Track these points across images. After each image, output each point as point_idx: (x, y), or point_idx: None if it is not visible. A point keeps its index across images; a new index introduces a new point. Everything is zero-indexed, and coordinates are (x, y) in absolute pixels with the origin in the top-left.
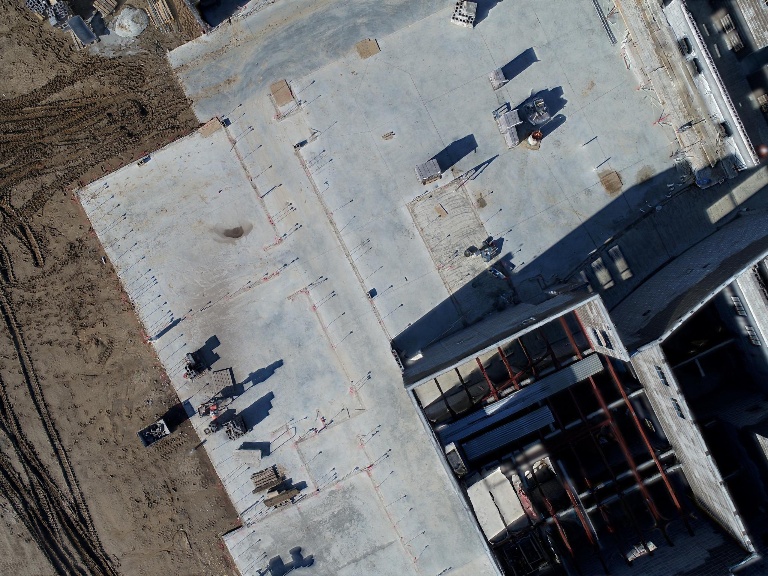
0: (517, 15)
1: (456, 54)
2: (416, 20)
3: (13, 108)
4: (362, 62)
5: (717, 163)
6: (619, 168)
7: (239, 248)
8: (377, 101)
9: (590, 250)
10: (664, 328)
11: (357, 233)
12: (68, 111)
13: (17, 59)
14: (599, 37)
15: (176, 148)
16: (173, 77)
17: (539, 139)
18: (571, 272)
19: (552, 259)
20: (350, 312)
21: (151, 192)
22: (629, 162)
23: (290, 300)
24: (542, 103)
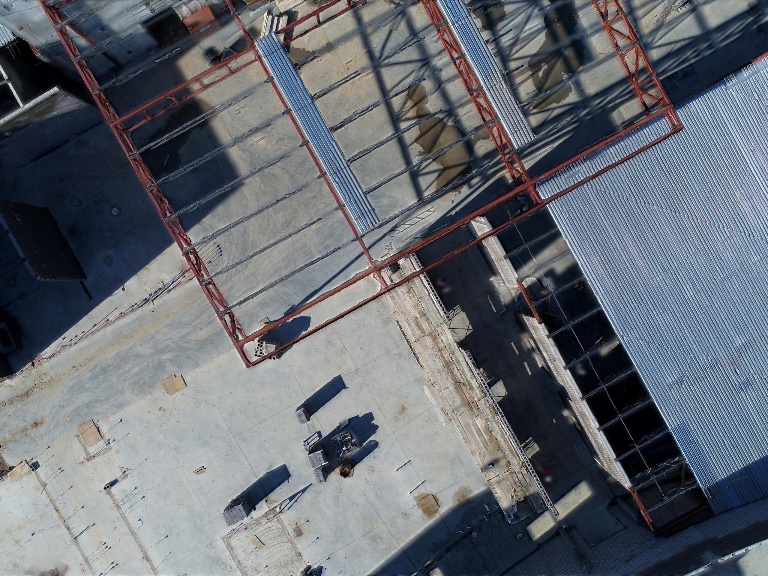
0: (323, 343)
1: (263, 385)
2: (221, 354)
3: None
4: (169, 398)
5: (524, 499)
6: (435, 490)
7: None
8: (186, 436)
9: (410, 573)
10: None
11: (174, 569)
12: None
13: None
14: (407, 361)
15: None
16: None
17: None
18: None
19: None
20: None
21: None
22: (445, 484)
23: None
24: (349, 438)
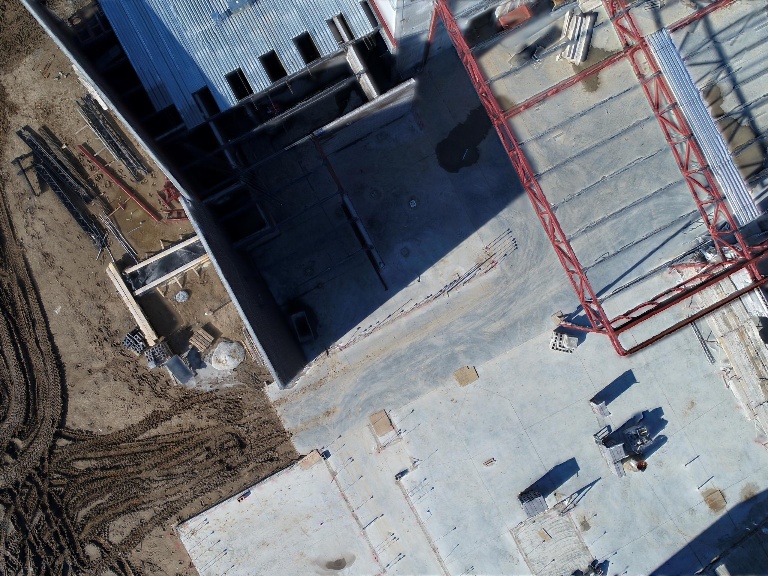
0: None
1: (555, 378)
2: (514, 346)
3: (110, 443)
4: (461, 390)
5: None
6: (722, 486)
7: None
8: (477, 428)
9: (696, 570)
10: None
11: (461, 561)
12: (166, 446)
13: (113, 394)
14: (697, 357)
15: (276, 481)
16: (271, 410)
17: (644, 470)
18: None
19: None
20: None
21: (252, 526)
22: (732, 480)
23: None
24: (645, 432)
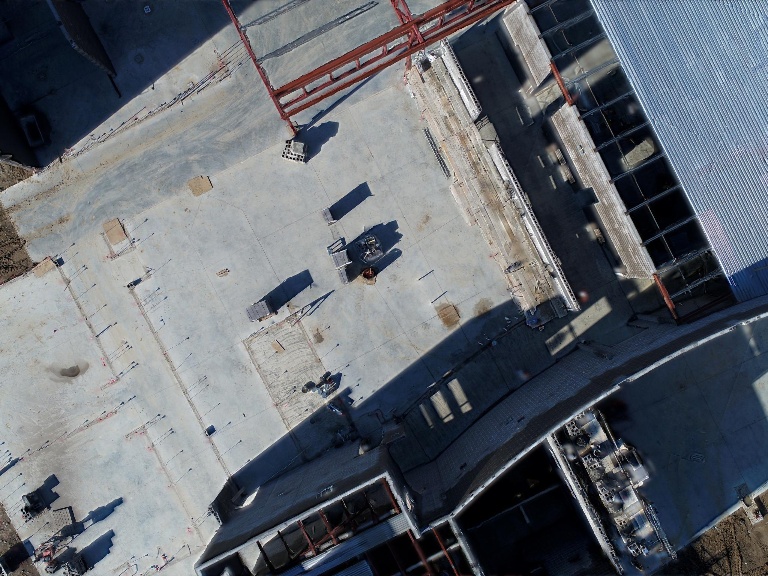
0: (350, 150)
1: (289, 190)
2: (248, 156)
3: None
4: (195, 199)
5: (546, 302)
6: (456, 301)
7: (76, 387)
8: (211, 238)
9: (429, 384)
10: (459, 500)
11: (194, 370)
12: None
13: None
14: (433, 170)
15: (10, 288)
16: (5, 217)
17: (370, 278)
18: (410, 406)
19: (391, 393)
20: (189, 449)
21: None
22: (466, 295)
23: (128, 438)
24: (373, 241)
